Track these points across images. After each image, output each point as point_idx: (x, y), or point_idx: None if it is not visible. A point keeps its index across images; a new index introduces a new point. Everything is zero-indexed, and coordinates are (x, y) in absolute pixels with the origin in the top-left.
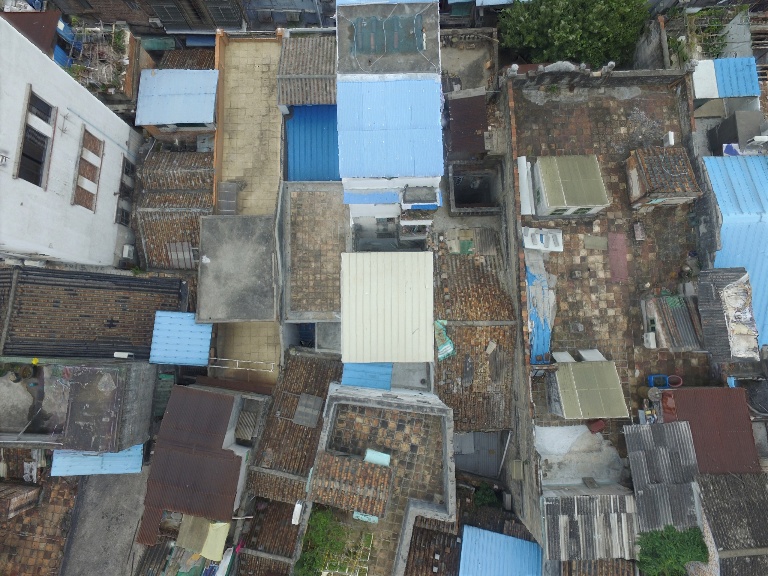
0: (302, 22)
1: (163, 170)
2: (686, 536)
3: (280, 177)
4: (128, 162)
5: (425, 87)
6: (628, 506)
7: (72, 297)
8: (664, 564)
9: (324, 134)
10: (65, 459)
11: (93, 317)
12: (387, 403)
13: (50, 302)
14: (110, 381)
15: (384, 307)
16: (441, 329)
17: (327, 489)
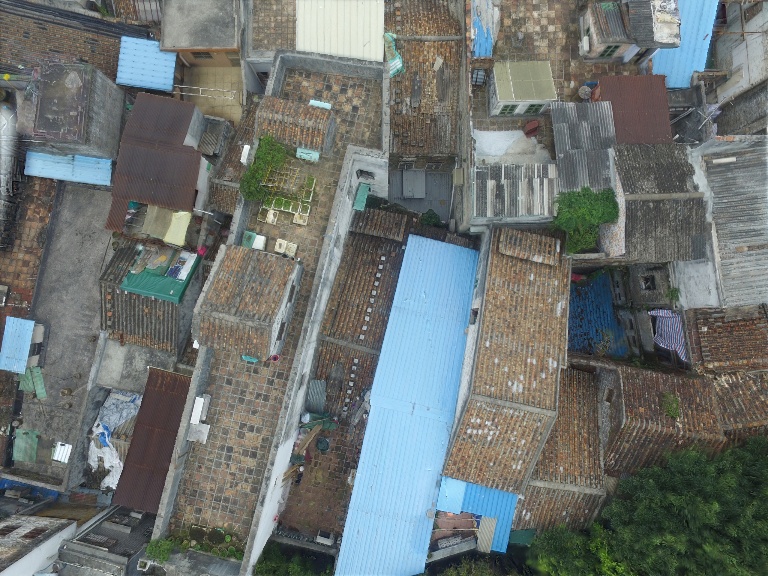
0: None
1: None
2: (600, 195)
3: None
4: None
5: None
6: (550, 172)
7: (41, 31)
8: (577, 212)
9: None
10: (37, 162)
11: (63, 53)
12: (329, 56)
13: (20, 32)
14: (76, 78)
15: (337, 21)
16: (391, 42)
17: (271, 121)
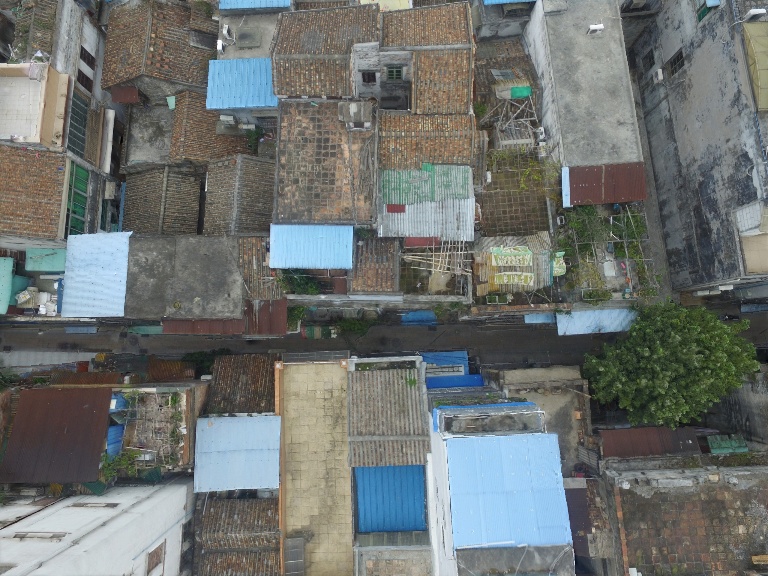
0: None
1: (224, 534)
2: None
3: (352, 538)
4: (186, 522)
5: None
6: None
7: None
8: None
9: (396, 478)
10: None
11: None
12: None
13: None
14: None
15: None
16: None
17: None
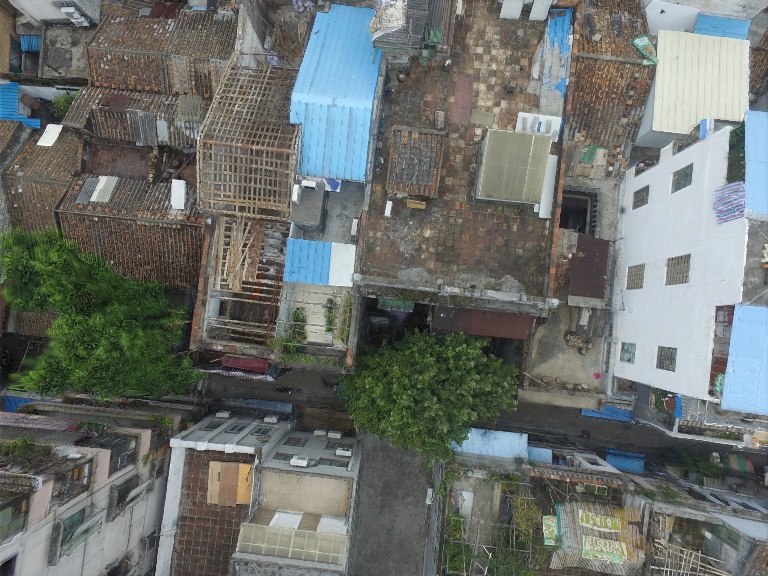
0: (695, 479)
1: None
2: None
3: None
4: None
5: (762, 207)
6: None
7: None
8: None
9: None
10: None
11: None
12: None
13: None
14: None
15: (705, 85)
16: None
17: None
